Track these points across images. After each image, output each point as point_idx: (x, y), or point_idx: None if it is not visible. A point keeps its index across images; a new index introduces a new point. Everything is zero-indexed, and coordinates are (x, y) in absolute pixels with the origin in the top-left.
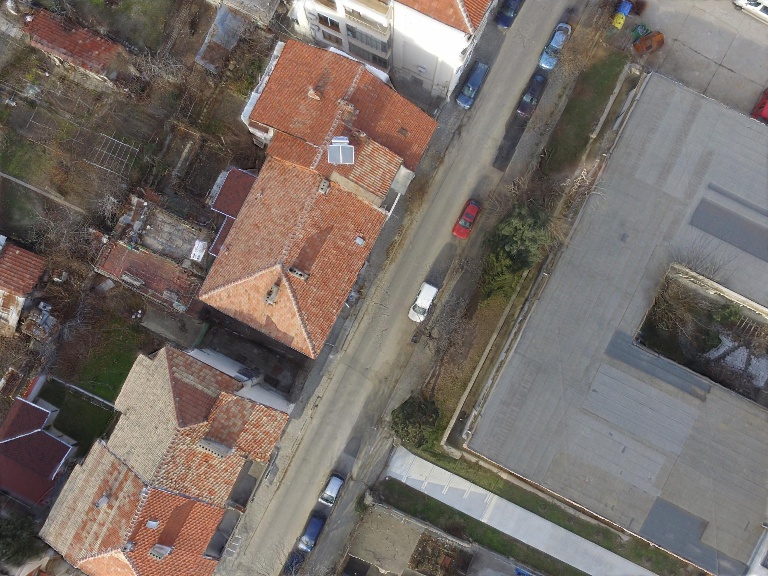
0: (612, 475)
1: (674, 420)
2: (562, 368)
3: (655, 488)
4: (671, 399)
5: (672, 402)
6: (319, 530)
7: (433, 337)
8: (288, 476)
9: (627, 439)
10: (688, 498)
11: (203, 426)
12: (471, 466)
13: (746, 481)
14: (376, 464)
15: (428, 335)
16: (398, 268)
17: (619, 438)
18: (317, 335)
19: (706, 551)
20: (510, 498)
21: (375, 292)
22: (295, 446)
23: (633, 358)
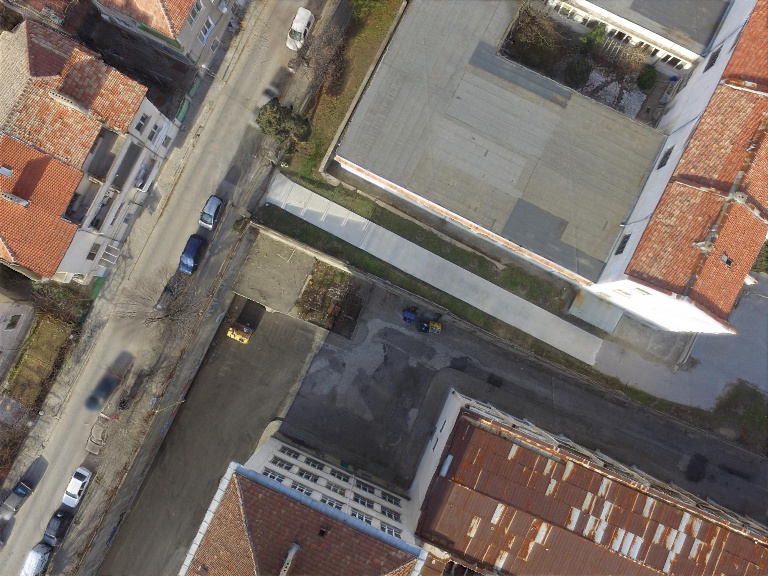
0: (475, 178)
1: (535, 125)
2: (427, 76)
3: (517, 190)
4: (533, 106)
5: (534, 109)
6: (198, 249)
7: (311, 67)
8: (171, 204)
9: (489, 143)
10: (548, 199)
11: (56, 80)
12: (349, 194)
13: (604, 182)
14: (256, 190)
15: (306, 64)
16: (277, 1)
17: (482, 142)
18: (176, 14)
19: (566, 250)
20: (388, 227)
21: (255, 24)
22: (177, 174)
23: (497, 68)
